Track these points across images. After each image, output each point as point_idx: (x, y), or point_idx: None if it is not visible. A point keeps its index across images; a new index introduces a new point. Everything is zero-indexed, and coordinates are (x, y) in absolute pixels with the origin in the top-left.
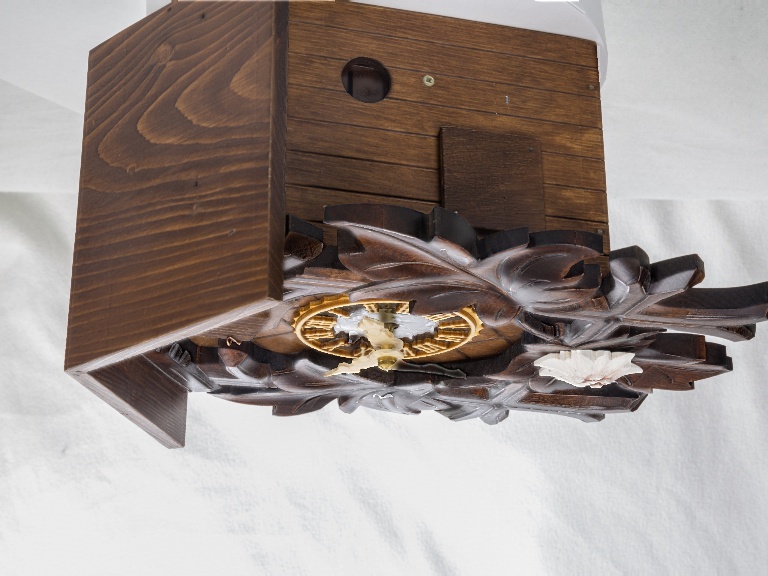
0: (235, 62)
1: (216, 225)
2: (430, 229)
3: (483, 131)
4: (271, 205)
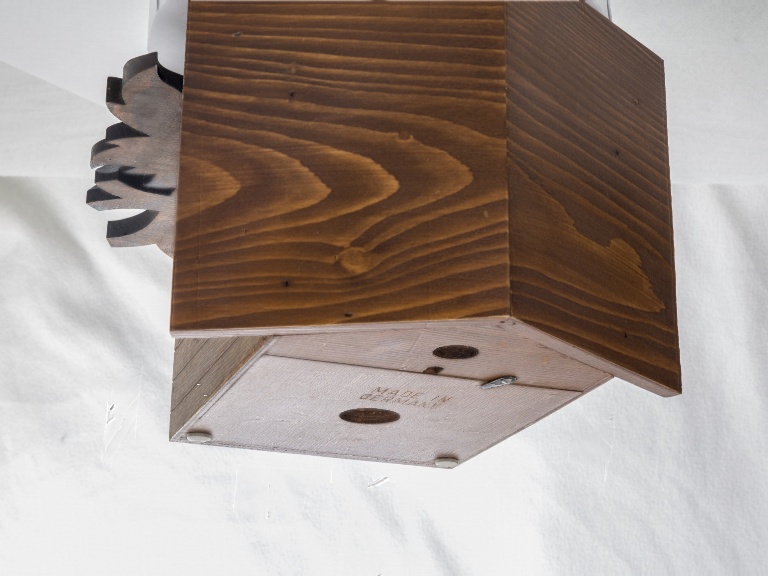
0: (232, 210)
1: (260, 45)
2: (120, 89)
3: None
4: None
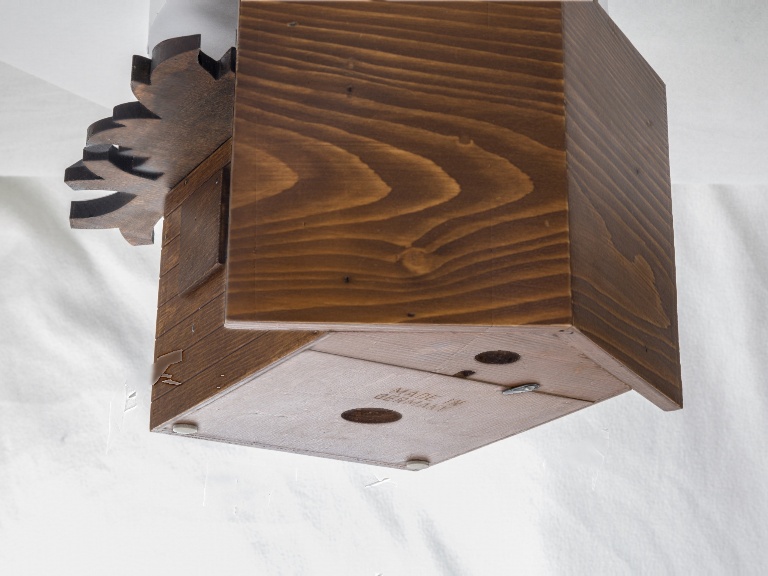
0: (290, 202)
1: (316, 37)
2: (146, 68)
3: (200, 277)
4: (237, 36)
